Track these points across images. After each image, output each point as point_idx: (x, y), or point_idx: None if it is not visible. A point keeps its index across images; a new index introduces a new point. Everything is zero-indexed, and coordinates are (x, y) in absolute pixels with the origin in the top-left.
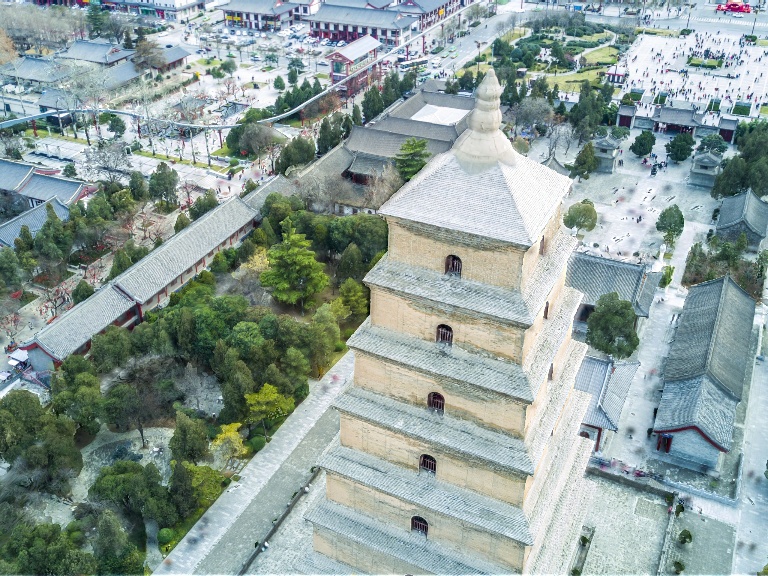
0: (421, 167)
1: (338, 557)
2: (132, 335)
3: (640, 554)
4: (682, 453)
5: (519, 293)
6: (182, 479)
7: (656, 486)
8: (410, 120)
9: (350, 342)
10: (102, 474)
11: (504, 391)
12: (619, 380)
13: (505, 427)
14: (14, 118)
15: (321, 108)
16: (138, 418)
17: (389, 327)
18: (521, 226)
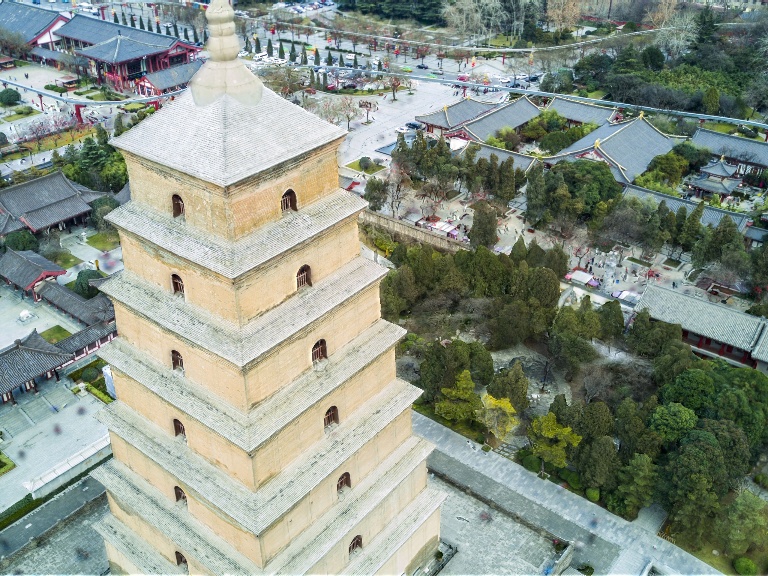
0: None
1: None
2: None
3: None
4: None
5: None
6: None
7: None
8: None
9: None
10: None
11: None
12: None
13: None
14: None
15: None
16: None
17: None
18: None
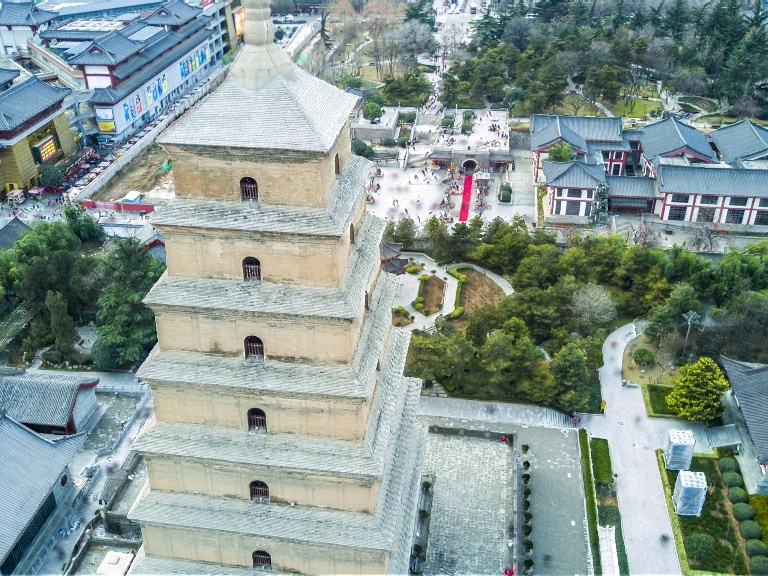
0: None
1: None
2: None
3: None
4: (82, 421)
5: None
6: None
7: None
8: None
9: (354, 312)
10: None
11: None
12: None
13: None
14: None
15: None
16: None
17: (341, 273)
18: None
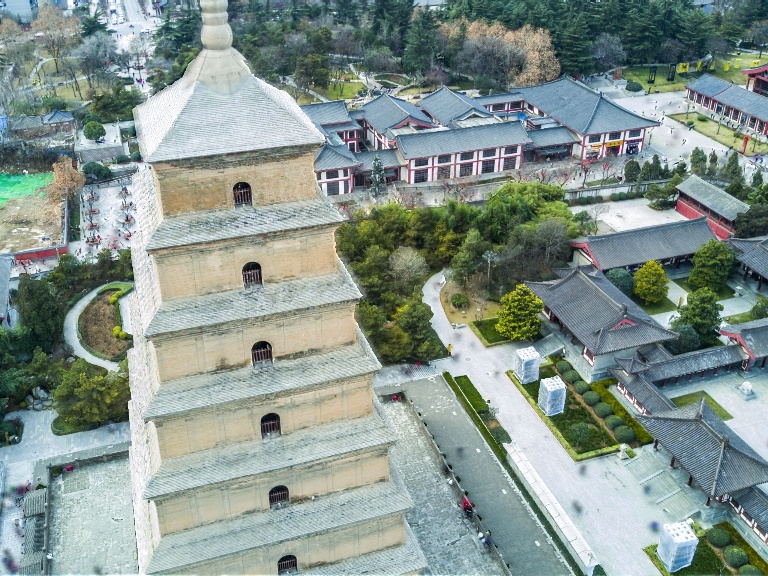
0: None
1: None
2: None
3: None
4: None
5: None
6: None
7: None
8: None
9: None
10: None
11: None
12: None
13: None
14: None
15: None
16: None
17: None
18: None
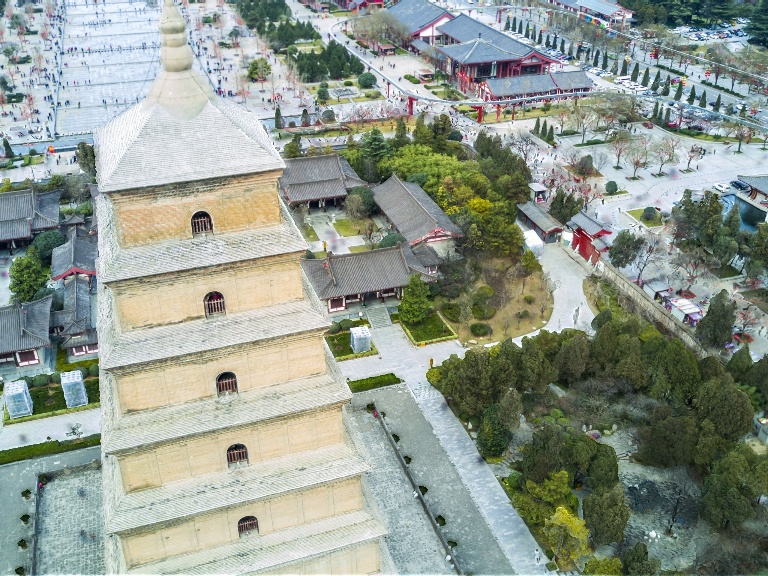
0: None
1: None
2: None
3: None
4: None
5: None
6: None
7: None
8: None
9: None
10: None
11: None
12: None
13: None
14: None
15: None
16: None
17: None
18: None
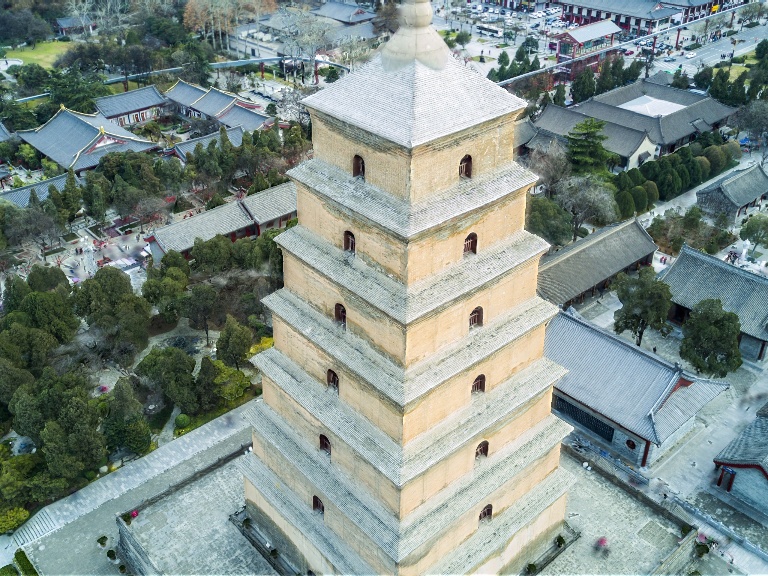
0: (593, 150)
1: (269, 464)
2: (233, 246)
3: (619, 575)
4: (744, 496)
5: (408, 204)
6: (207, 373)
7: (681, 515)
8: (614, 106)
9: (276, 238)
10: (150, 353)
11: (383, 309)
12: (692, 396)
13: (390, 352)
14: (246, 59)
15: (529, 85)
16: (204, 316)
17: (311, 229)
18: (409, 127)
